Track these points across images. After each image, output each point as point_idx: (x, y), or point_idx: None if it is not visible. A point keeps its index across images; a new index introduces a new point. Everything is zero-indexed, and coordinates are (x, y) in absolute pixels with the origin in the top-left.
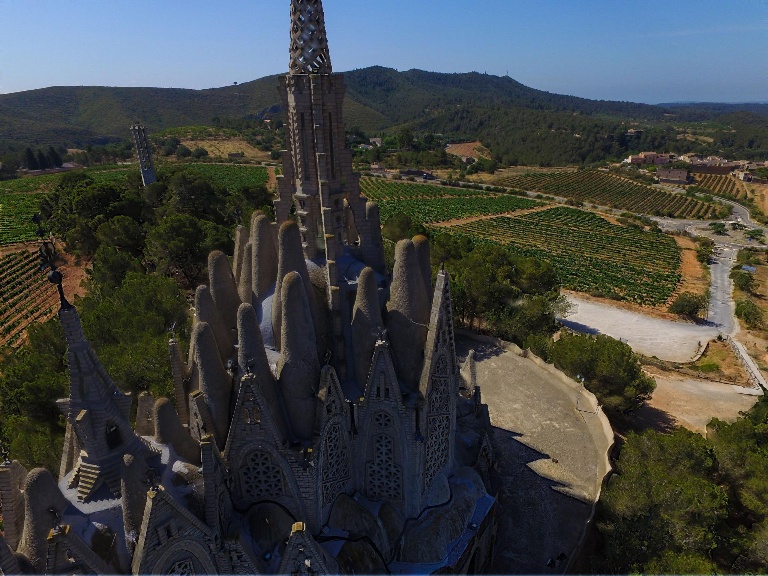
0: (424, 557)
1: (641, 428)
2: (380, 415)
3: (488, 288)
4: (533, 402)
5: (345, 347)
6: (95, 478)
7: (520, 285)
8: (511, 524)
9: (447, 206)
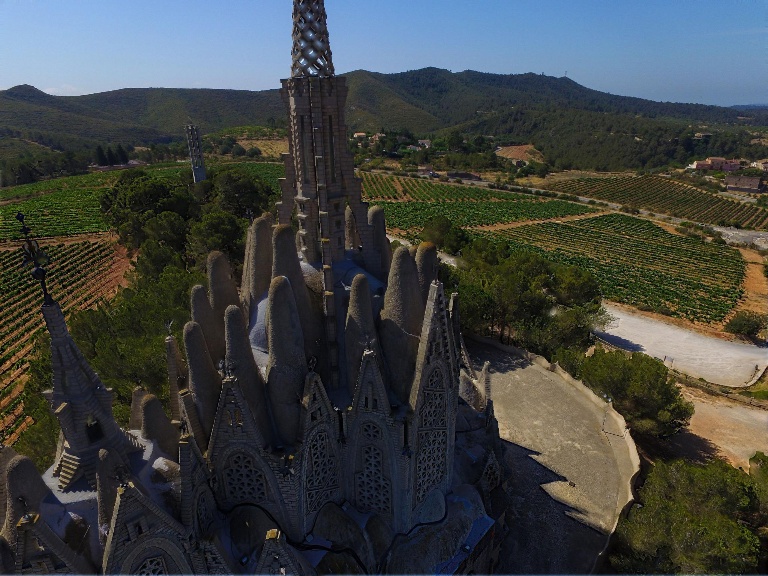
0: (410, 575)
1: (677, 456)
2: (369, 426)
3: (519, 297)
4: (555, 420)
5: (339, 354)
6: (75, 469)
7: (558, 295)
8: (516, 548)
9: (493, 210)
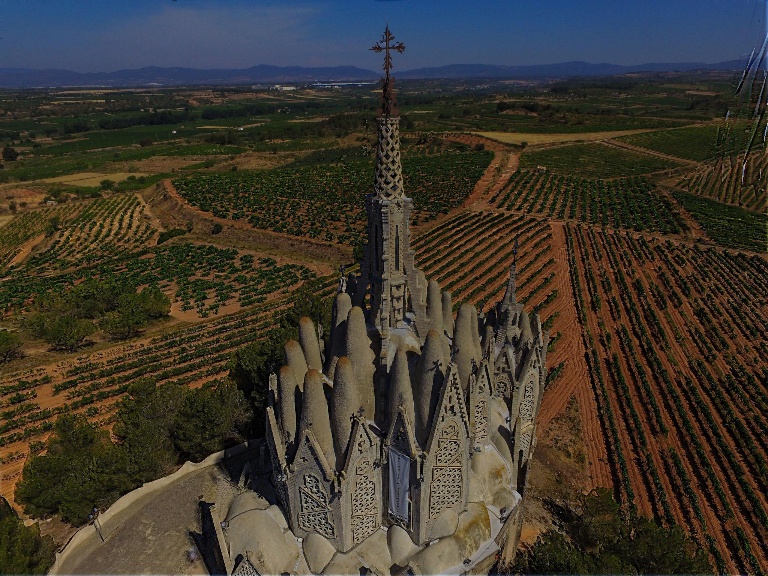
0: None
1: None
2: None
3: None
4: (124, 571)
5: None
6: None
7: None
8: None
9: None
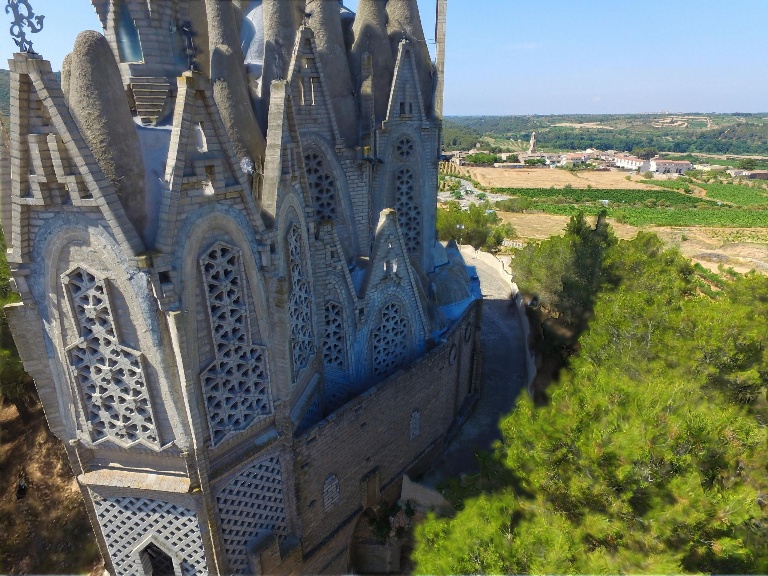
0: (456, 296)
1: None
2: (402, 142)
3: None
4: None
5: None
6: (165, 92)
7: None
8: None
9: None
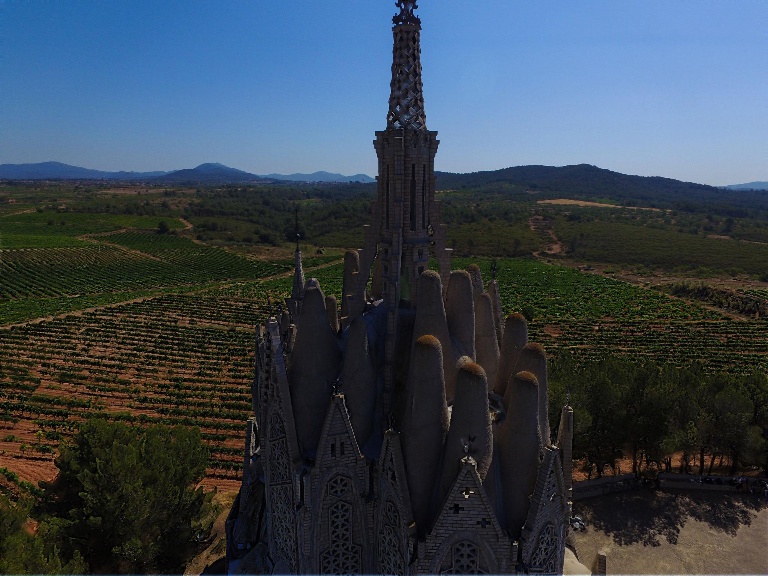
0: None
1: None
2: None
3: None
4: None
5: None
6: None
7: None
8: None
9: None
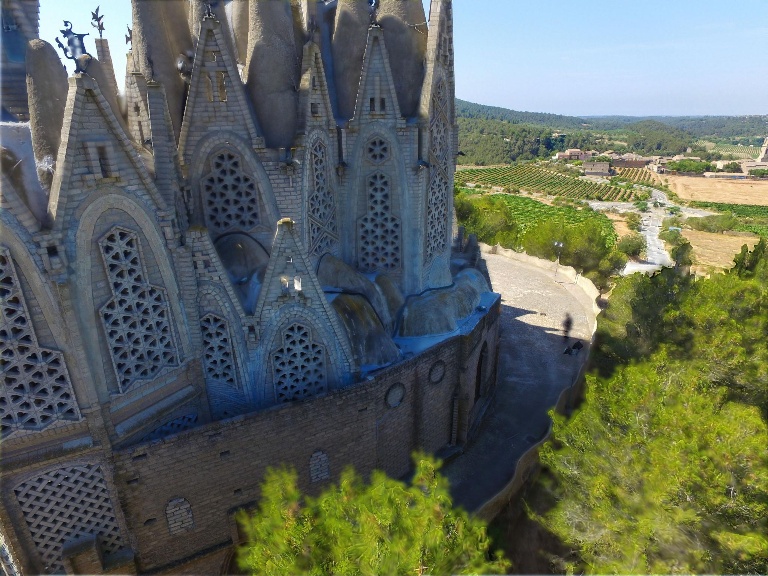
0: (432, 327)
1: None
2: (374, 143)
3: None
4: (510, 279)
5: None
6: None
7: None
8: (509, 358)
9: None
